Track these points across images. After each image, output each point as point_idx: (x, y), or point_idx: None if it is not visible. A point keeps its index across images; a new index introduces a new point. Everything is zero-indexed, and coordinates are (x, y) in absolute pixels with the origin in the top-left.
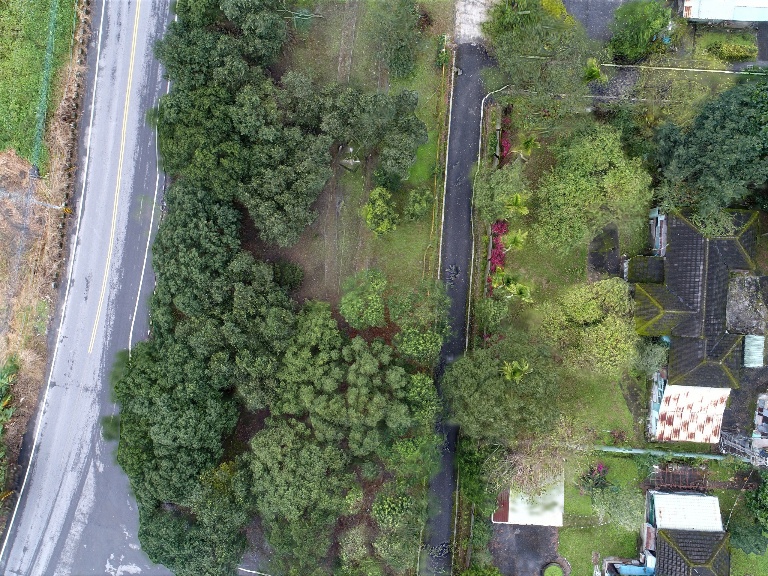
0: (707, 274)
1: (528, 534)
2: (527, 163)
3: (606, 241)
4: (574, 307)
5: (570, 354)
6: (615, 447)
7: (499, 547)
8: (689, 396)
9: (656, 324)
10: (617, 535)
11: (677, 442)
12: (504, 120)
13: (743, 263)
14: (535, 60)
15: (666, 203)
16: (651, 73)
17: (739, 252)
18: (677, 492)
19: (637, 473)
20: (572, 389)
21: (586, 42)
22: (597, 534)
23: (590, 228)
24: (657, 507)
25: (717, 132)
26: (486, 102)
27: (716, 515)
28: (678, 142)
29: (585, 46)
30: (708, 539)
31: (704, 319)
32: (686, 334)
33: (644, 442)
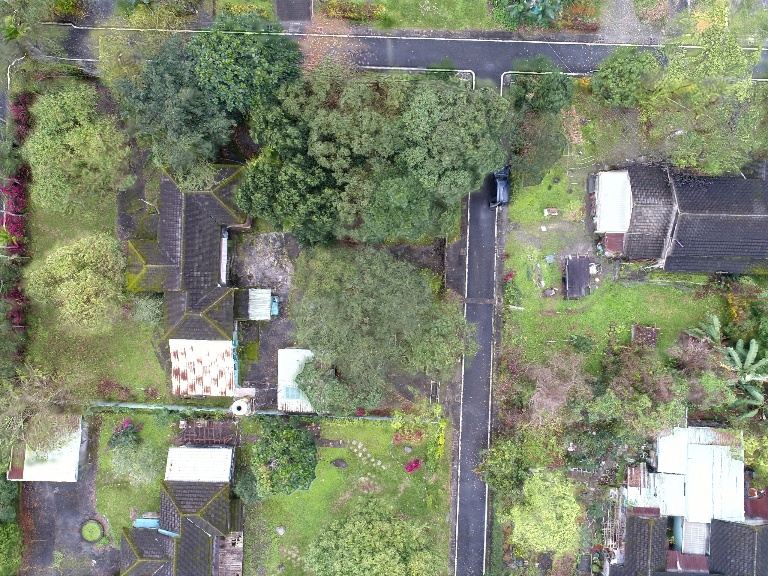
0: (185, 228)
1: (67, 492)
2: (8, 124)
3: (133, 202)
4: (52, 264)
5: (61, 311)
6: (143, 404)
7: (39, 506)
8: (195, 350)
9: (145, 279)
10: (154, 491)
11: (209, 398)
12: (21, 85)
13: (229, 217)
14: (55, 26)
15: (156, 161)
16: (173, 36)
17: (221, 206)
18: (198, 446)
19: (172, 429)
20: (105, 348)
21: (109, 7)
22: (134, 490)
23: (74, 187)
24: (169, 460)
25: (168, 87)
26: (12, 69)
27: (226, 466)
28: (137, 99)
29: (2, 4)
30: (206, 489)
31: (182, 272)
32: (171, 288)
33: (178, 399)
